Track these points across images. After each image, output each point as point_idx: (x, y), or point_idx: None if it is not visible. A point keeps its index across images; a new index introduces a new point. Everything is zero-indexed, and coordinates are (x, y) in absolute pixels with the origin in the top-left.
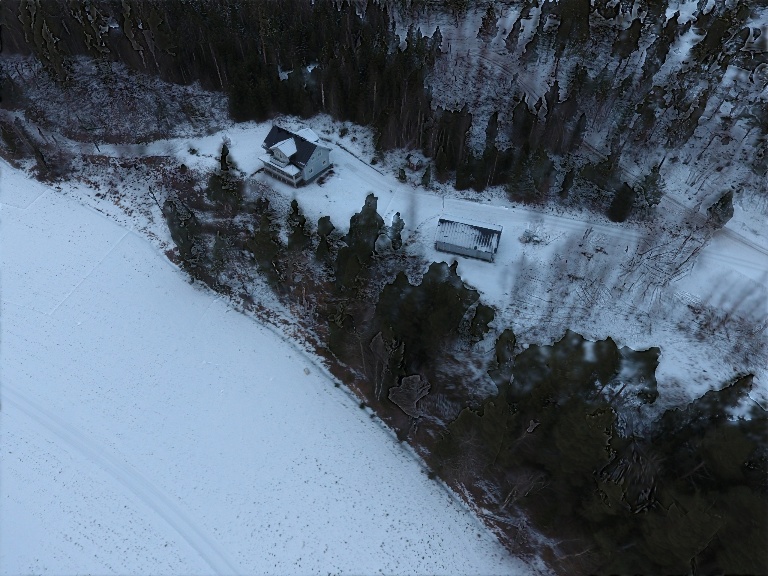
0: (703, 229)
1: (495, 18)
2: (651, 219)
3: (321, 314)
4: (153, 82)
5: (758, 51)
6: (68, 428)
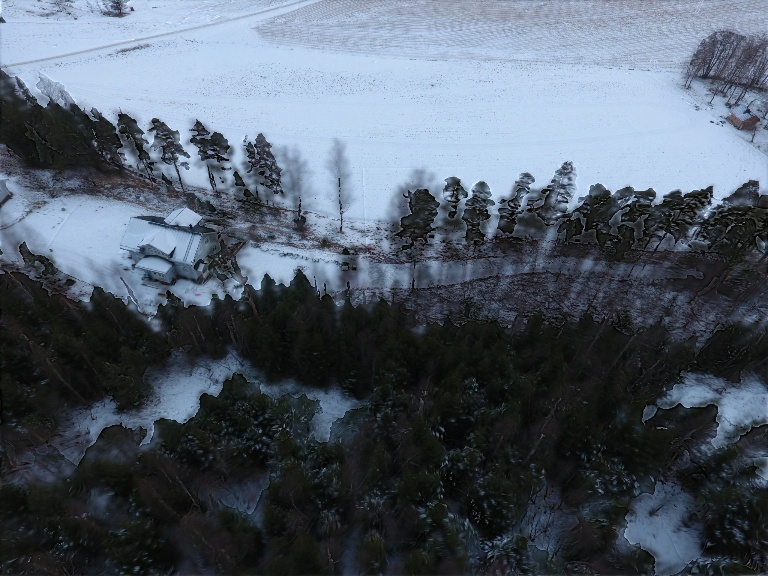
0: None
1: None
2: None
3: None
4: None
5: None
6: (293, 137)
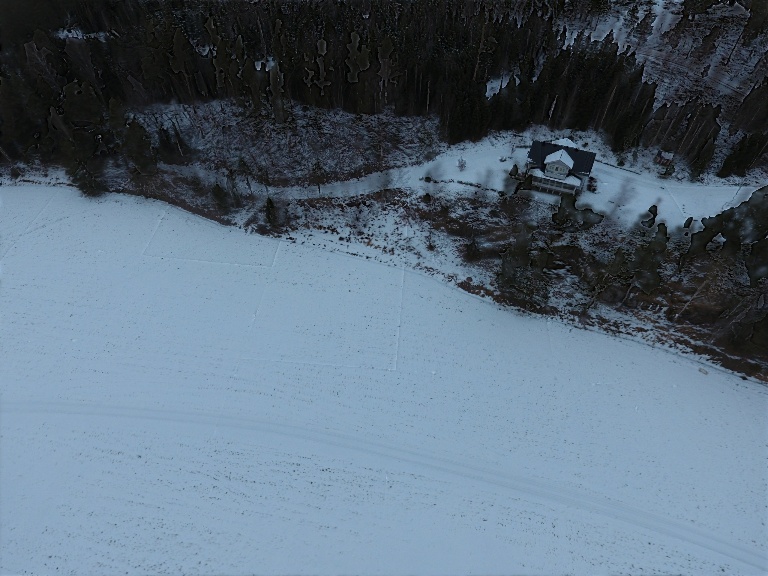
0: None
1: None
2: None
3: (682, 314)
4: (337, 115)
5: None
6: (522, 480)
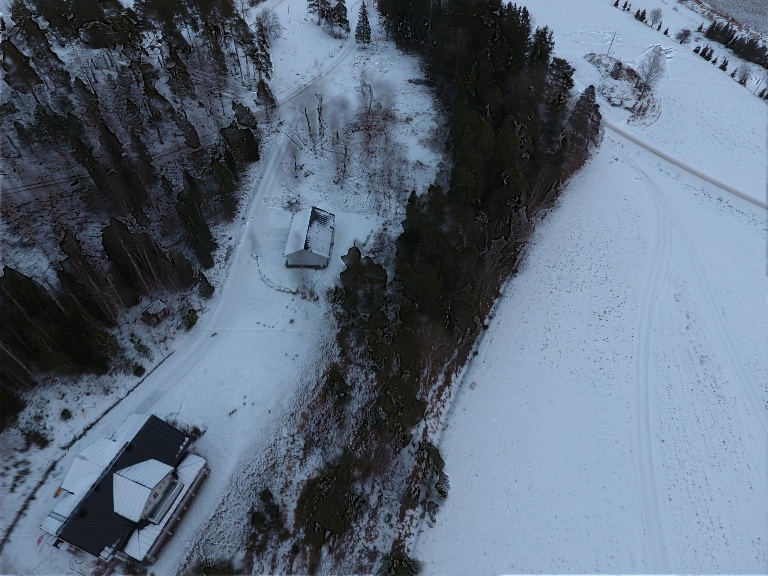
0: (269, 117)
1: None
2: (257, 139)
3: None
4: None
5: (5, 36)
6: None
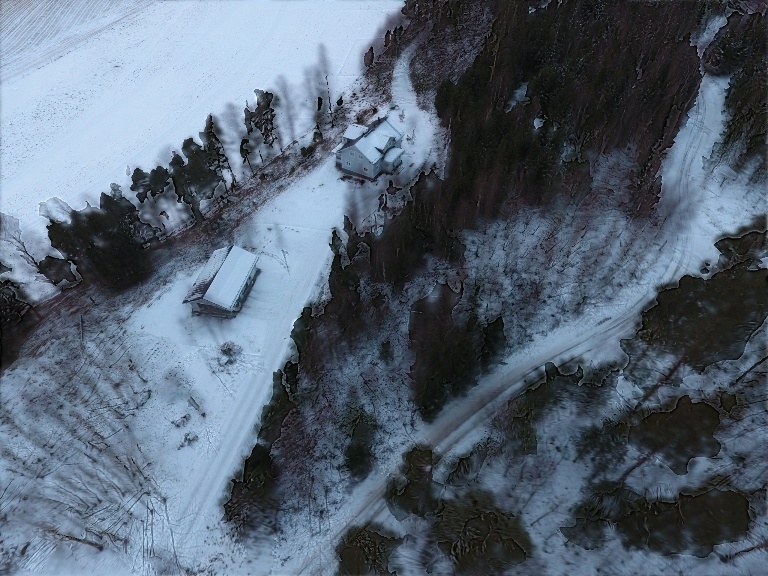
0: None
1: (766, 242)
2: (244, 540)
3: None
4: None
5: None
6: None
